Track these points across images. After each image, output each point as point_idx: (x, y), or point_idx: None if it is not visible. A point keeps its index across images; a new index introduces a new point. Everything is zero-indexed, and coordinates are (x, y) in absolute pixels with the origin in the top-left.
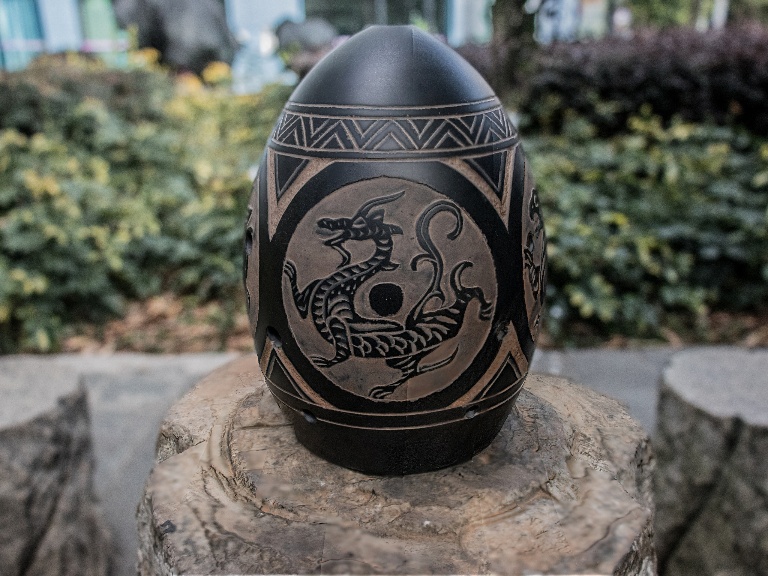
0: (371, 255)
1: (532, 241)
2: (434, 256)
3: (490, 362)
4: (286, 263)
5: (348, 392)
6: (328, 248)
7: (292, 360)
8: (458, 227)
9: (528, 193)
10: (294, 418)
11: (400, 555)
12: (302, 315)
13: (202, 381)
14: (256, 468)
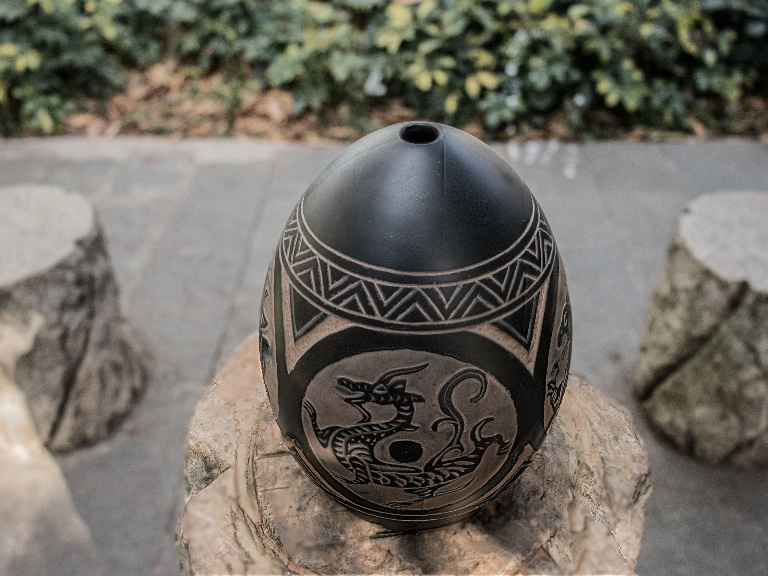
0: (392, 418)
1: (557, 365)
2: (455, 419)
3: (504, 476)
4: (305, 401)
5: (367, 501)
6: (348, 404)
7: (313, 464)
8: (482, 390)
9: (558, 321)
10: None
11: None
12: (322, 445)
13: (222, 373)
14: (281, 515)
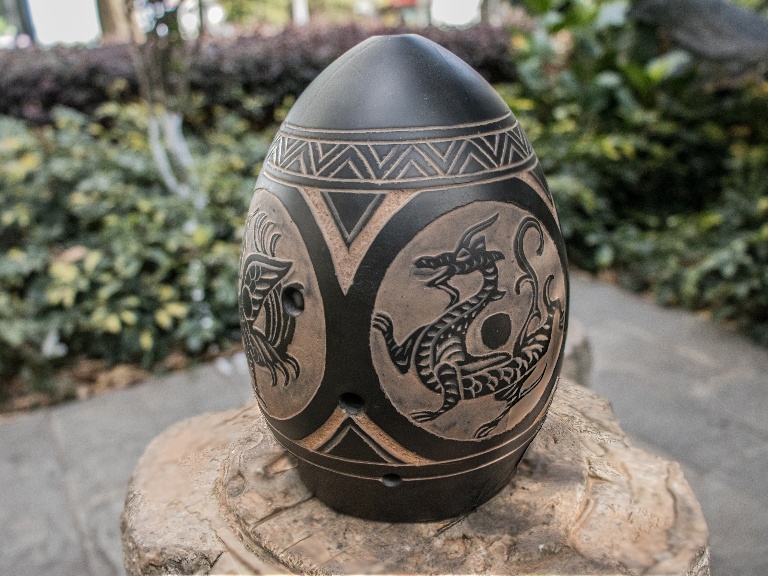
0: (479, 287)
1: None
2: (531, 275)
3: None
4: (376, 316)
5: (452, 440)
6: (432, 289)
7: (380, 424)
8: (541, 241)
9: None
10: (308, 489)
11: None
12: (402, 370)
13: (141, 483)
14: (324, 560)
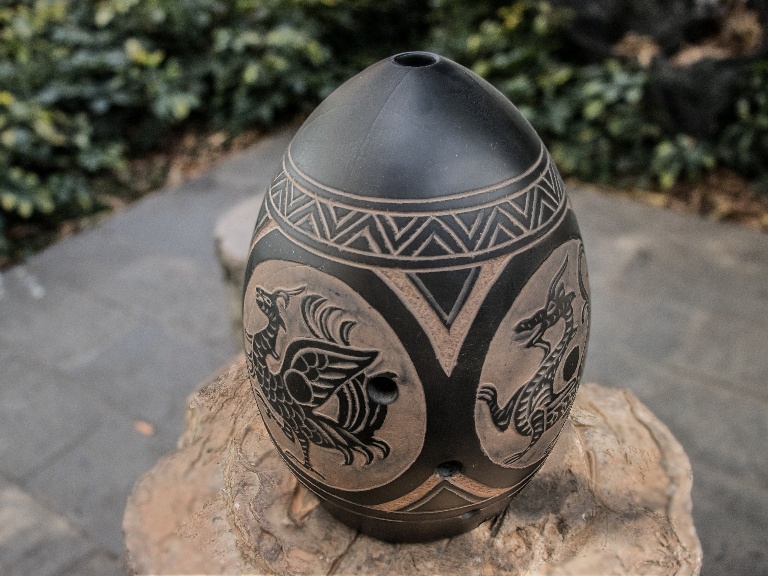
0: (563, 332)
1: None
2: None
3: None
4: (481, 389)
5: (530, 466)
6: (530, 349)
7: (474, 477)
8: None
9: None
10: (349, 527)
11: (608, 556)
12: (502, 429)
13: None
14: None
